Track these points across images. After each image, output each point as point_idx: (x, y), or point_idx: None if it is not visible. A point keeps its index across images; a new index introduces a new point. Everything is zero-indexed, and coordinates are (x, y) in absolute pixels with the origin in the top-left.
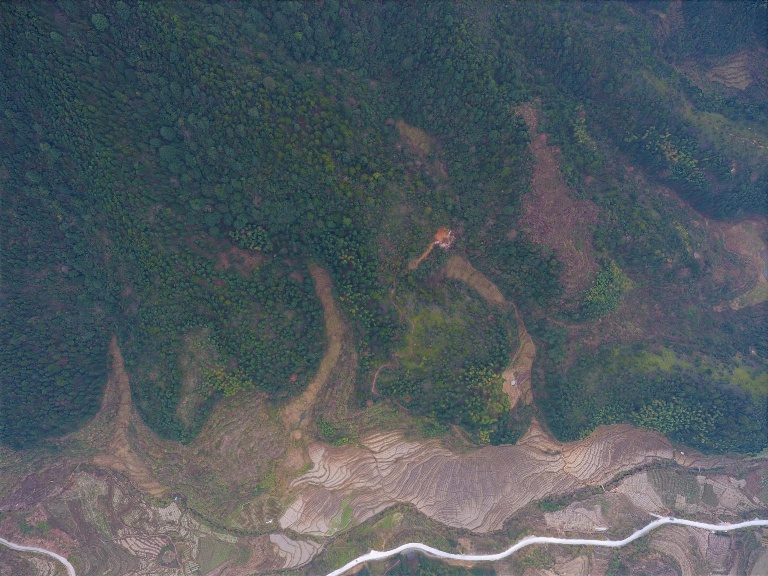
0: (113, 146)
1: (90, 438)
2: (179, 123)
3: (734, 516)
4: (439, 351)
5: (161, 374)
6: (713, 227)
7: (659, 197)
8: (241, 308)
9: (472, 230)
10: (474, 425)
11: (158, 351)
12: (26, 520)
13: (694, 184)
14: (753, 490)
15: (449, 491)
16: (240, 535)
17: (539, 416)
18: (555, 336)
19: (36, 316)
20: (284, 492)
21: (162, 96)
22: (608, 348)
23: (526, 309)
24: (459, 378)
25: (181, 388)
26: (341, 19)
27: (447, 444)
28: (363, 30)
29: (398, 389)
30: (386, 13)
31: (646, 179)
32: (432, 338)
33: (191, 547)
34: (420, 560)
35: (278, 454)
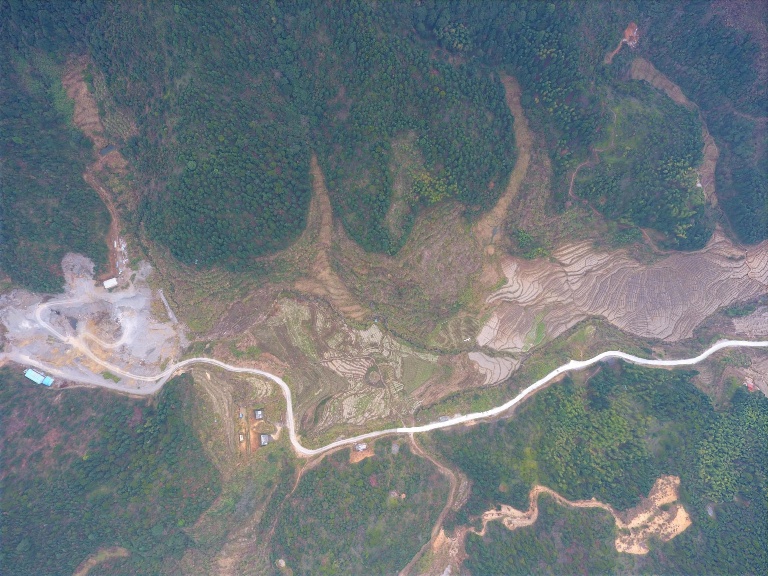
0: None
1: (296, 258)
2: None
3: None
4: (640, 141)
5: (374, 177)
6: None
7: None
8: (456, 98)
9: (656, 28)
10: (671, 222)
11: (373, 151)
12: (236, 346)
13: None
14: None
15: (638, 302)
16: (441, 353)
17: (723, 220)
18: (741, 131)
19: (255, 121)
20: (480, 309)
21: None
22: None
23: (711, 106)
24: (657, 171)
25: None
26: None
27: (635, 254)
28: None
29: (597, 187)
30: None
31: None
32: (635, 126)
33: (395, 367)
34: (623, 363)
35: (474, 269)
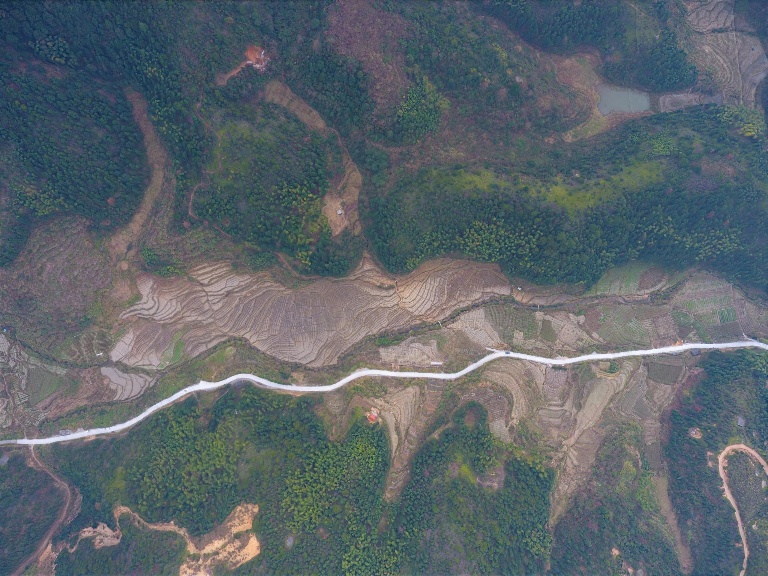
0: None
1: None
2: None
3: (572, 351)
4: (248, 165)
5: None
6: (545, 59)
7: (483, 24)
8: (37, 113)
9: (287, 52)
10: (293, 248)
11: None
12: None
13: (516, 9)
14: (592, 326)
15: (282, 326)
16: (70, 367)
17: (370, 248)
18: (376, 160)
19: None
20: (113, 324)
21: None
22: (426, 169)
23: (346, 134)
24: (273, 196)
25: None
26: None
27: (278, 277)
28: None
29: (213, 209)
30: None
31: (472, 8)
32: (238, 150)
33: (20, 378)
34: (246, 387)
35: (104, 284)
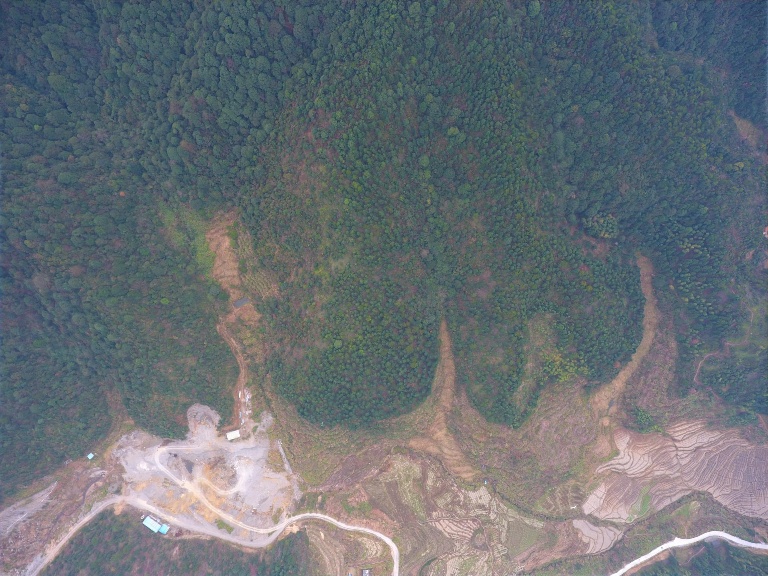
0: (524, 131)
1: (416, 421)
2: (571, 110)
3: None
4: None
5: (509, 358)
6: None
7: None
8: (602, 294)
9: None
10: None
11: (512, 335)
12: (348, 500)
13: None
14: None
15: (744, 481)
16: (546, 520)
17: None
18: None
19: (399, 298)
20: (589, 478)
21: (568, 83)
22: None
23: None
24: None
25: (525, 372)
26: (715, 10)
27: (746, 434)
28: (726, 22)
29: (724, 378)
30: (745, 5)
31: None
32: None
33: (500, 531)
34: (729, 548)
35: (588, 440)
